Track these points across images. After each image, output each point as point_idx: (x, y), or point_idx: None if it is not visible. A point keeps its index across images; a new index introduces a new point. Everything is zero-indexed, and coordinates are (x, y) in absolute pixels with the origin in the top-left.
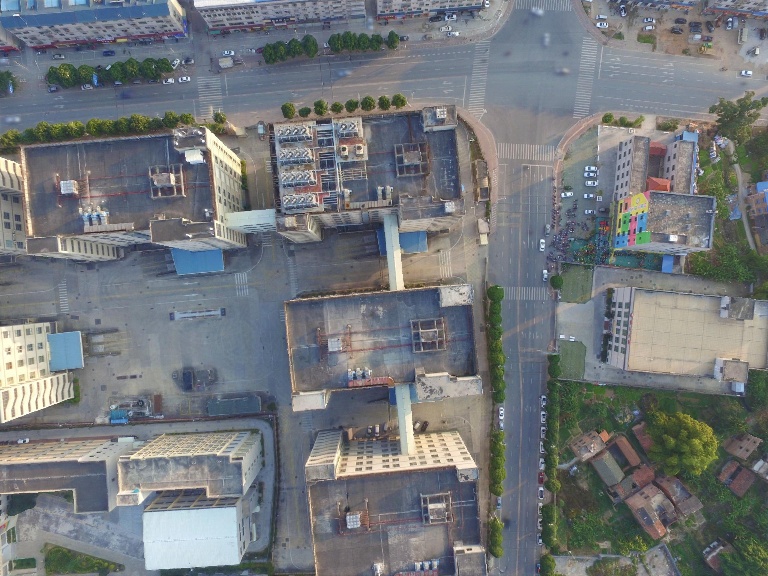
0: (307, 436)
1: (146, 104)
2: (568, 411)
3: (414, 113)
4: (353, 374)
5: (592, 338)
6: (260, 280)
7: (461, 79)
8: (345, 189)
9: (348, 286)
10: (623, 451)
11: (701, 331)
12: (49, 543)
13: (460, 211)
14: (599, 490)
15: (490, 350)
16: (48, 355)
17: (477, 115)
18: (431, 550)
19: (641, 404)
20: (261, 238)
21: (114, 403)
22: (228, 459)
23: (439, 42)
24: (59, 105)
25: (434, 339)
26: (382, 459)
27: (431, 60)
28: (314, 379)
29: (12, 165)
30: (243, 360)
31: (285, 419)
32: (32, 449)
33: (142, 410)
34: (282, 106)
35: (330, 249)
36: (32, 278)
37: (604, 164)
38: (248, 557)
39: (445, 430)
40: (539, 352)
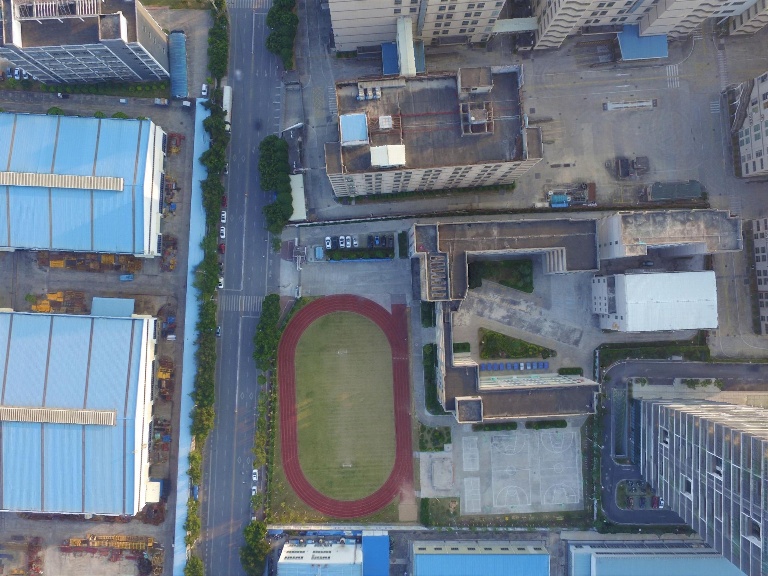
0: None
1: None
2: None
3: None
4: None
5: None
6: (691, 72)
7: None
8: None
9: None
10: None
11: None
12: (483, 328)
13: None
14: None
15: None
16: None
17: None
18: None
19: None
20: (692, 31)
21: (549, 190)
22: (723, 216)
23: None
24: None
25: None
26: None
27: None
28: None
29: None
30: (674, 150)
31: None
32: None
33: (580, 196)
34: None
35: (759, 43)
36: None
37: None
38: (678, 344)
39: None
40: None
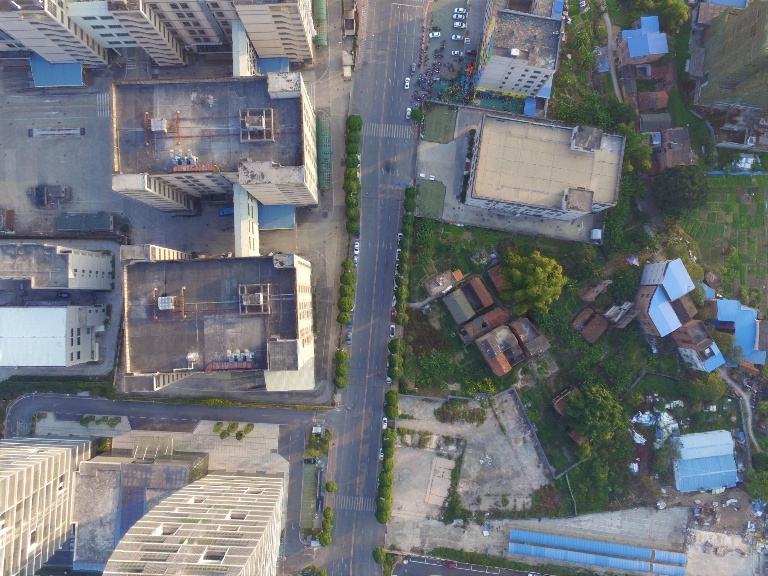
0: None
1: None
2: (421, 245)
3: None
4: (178, 159)
5: (452, 178)
6: None
7: None
8: None
9: None
10: (476, 291)
11: (551, 162)
12: None
13: None
14: (451, 331)
15: (345, 179)
16: None
17: None
18: (247, 343)
19: (499, 249)
20: (126, 60)
21: None
22: None
23: None
24: None
25: (259, 125)
26: None
27: None
28: (139, 163)
29: None
30: (99, 180)
31: (138, 242)
32: None
33: None
34: None
35: (194, 75)
36: None
37: (474, 7)
38: (91, 380)
39: None
40: (399, 190)
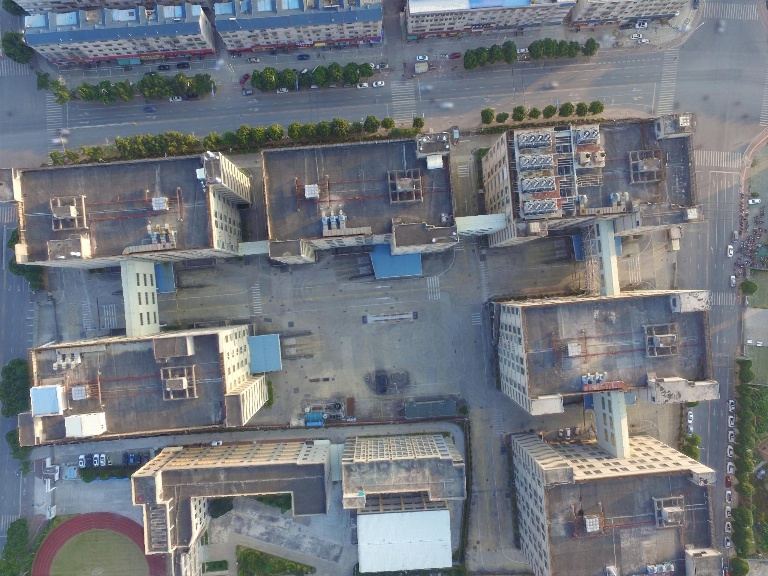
0: (498, 439)
1: (340, 108)
2: (760, 415)
3: (648, 120)
4: None
5: None
6: (452, 284)
7: (650, 86)
8: (584, 195)
9: (539, 290)
10: None
11: None
12: (241, 545)
13: (698, 218)
14: None
15: None
16: (248, 358)
17: None
18: (662, 553)
19: None
20: None
21: (307, 406)
22: (449, 462)
23: (629, 49)
24: (253, 108)
25: (672, 344)
26: (601, 463)
27: (621, 67)
28: (548, 383)
29: (233, 168)
30: (435, 363)
31: (476, 422)
32: (232, 451)
33: (337, 413)
34: (483, 111)
35: (521, 253)
36: (226, 280)
37: None
38: None
39: (634, 434)
40: (726, 357)
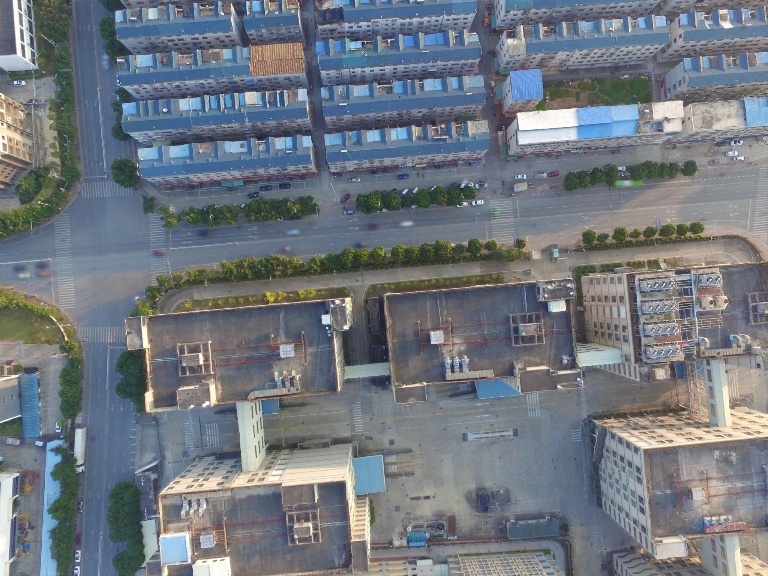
0: (598, 556)
1: (439, 226)
2: None
3: None
4: None
5: None
6: (551, 401)
7: (746, 202)
8: (706, 339)
9: (638, 407)
10: None
11: None
12: None
13: None
14: None
15: None
16: (353, 480)
17: (762, 238)
18: None
19: None
20: None
21: (408, 524)
22: None
23: (725, 166)
24: (354, 227)
25: None
26: None
27: (717, 184)
28: (669, 524)
29: None
30: (535, 480)
31: (577, 539)
32: (338, 575)
33: (439, 532)
34: (585, 233)
35: None
36: (327, 399)
37: None
38: None
39: None
40: None
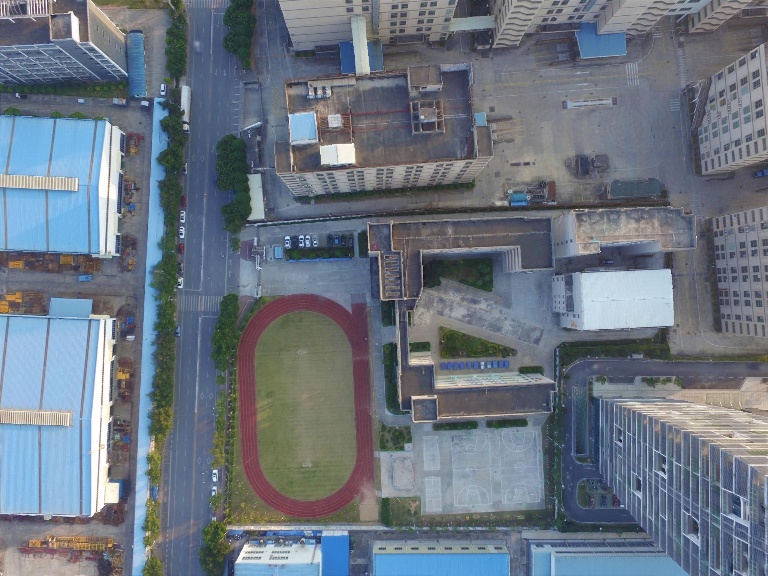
0: (697, 224)
1: None
2: None
3: None
4: None
5: None
6: (651, 70)
7: None
8: None
9: None
10: None
11: None
12: (444, 327)
13: None
14: None
15: None
16: None
17: None
18: None
19: None
20: (652, 29)
21: (509, 189)
22: (678, 214)
23: None
24: None
25: None
26: None
27: None
28: None
29: None
30: (634, 148)
31: (675, 207)
32: None
33: (540, 194)
34: None
35: (719, 41)
36: None
37: None
38: (639, 343)
39: None
40: None
